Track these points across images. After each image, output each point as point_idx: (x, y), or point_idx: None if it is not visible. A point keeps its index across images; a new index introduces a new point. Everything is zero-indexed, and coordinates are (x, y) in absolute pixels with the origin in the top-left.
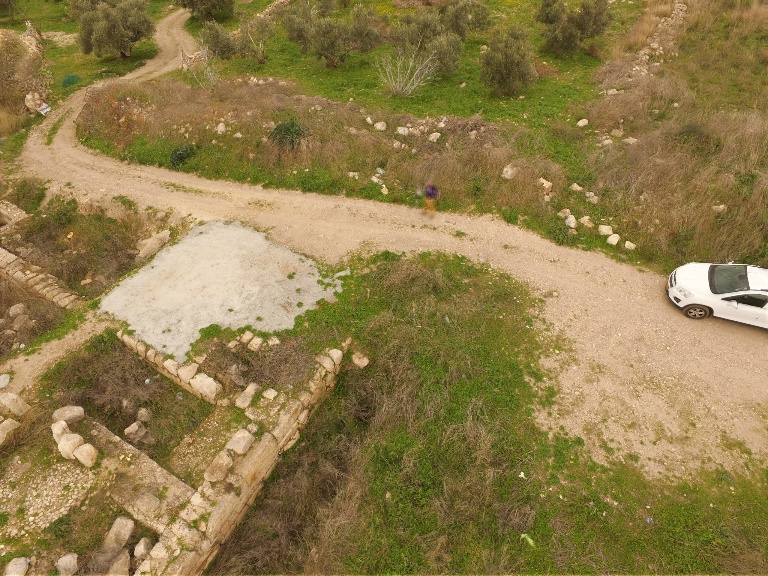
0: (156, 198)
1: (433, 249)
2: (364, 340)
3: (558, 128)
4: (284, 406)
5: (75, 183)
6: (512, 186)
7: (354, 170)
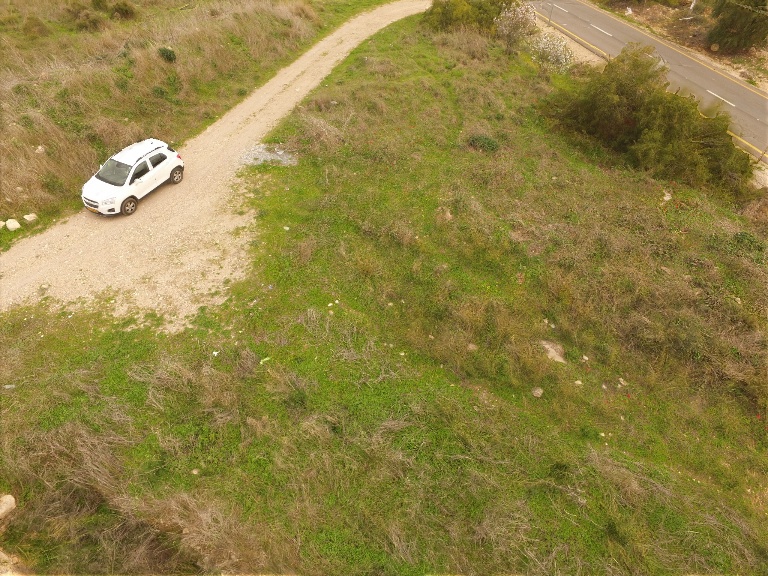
0: None
1: None
2: None
3: None
4: None
5: None
6: None
7: None
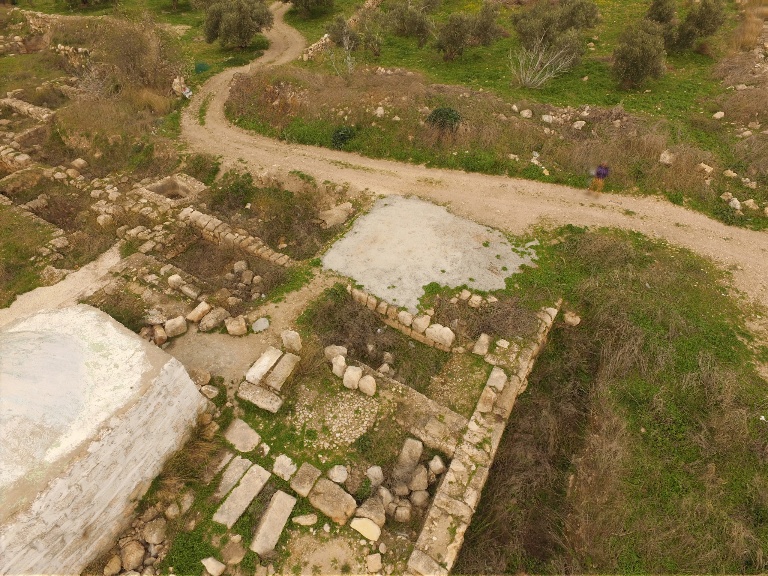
0: (329, 174)
1: (609, 225)
2: (575, 301)
3: (697, 119)
4: (520, 354)
5: (246, 159)
6: (676, 170)
7: (513, 153)
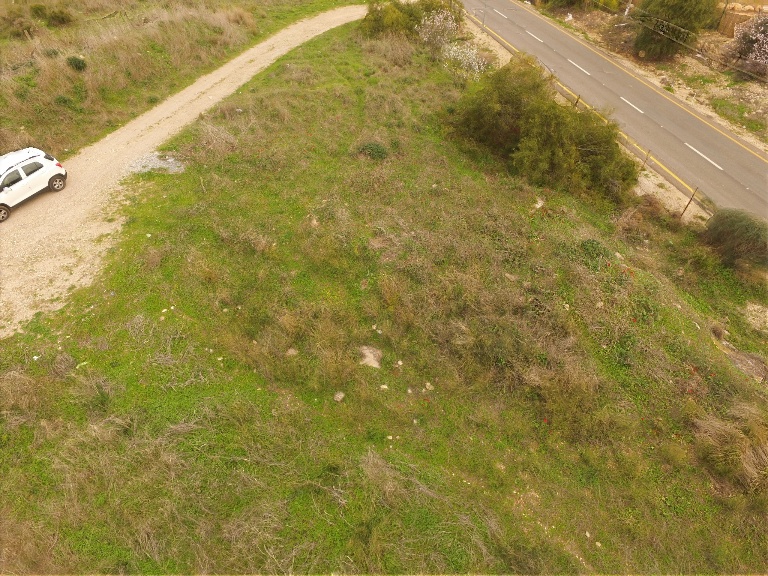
0: None
1: None
2: None
3: None
4: None
5: None
6: None
7: None
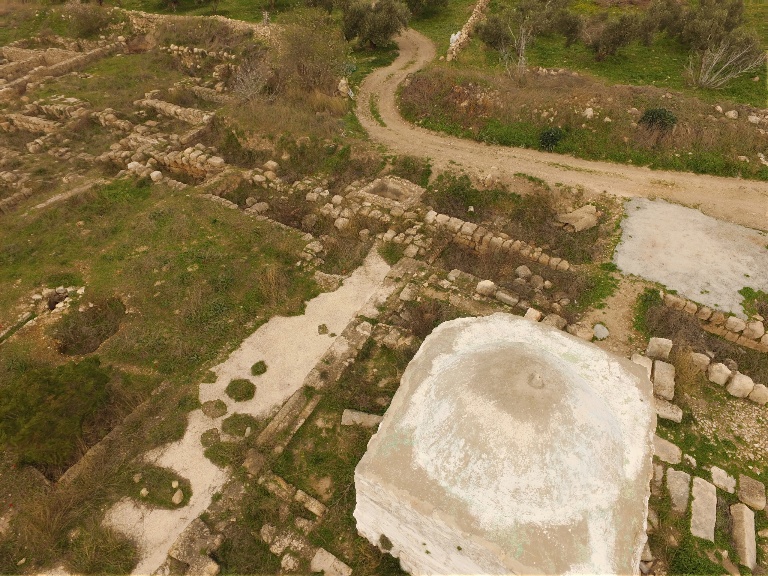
0: (555, 176)
1: None
2: None
3: None
4: None
5: (457, 161)
6: None
7: (741, 154)
